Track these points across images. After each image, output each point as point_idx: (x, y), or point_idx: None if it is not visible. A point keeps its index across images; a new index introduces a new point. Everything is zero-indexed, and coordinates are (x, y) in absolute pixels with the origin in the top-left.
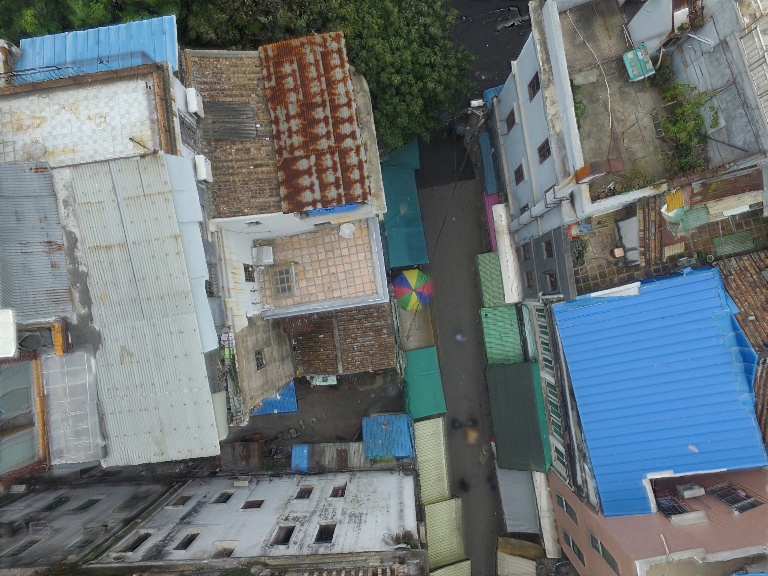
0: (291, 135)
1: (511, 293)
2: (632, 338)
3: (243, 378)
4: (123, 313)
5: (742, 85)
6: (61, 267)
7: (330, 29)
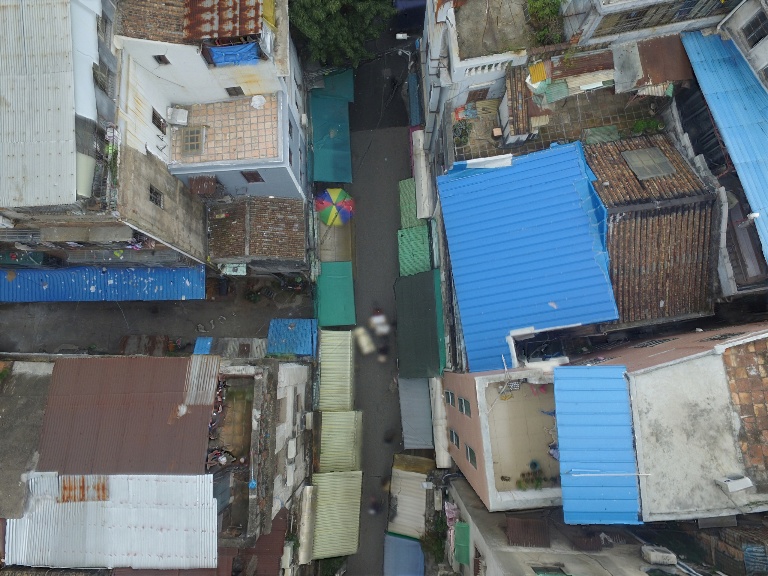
0: None
1: (423, 209)
2: (503, 205)
3: (127, 186)
4: (8, 66)
5: None
6: None
7: None
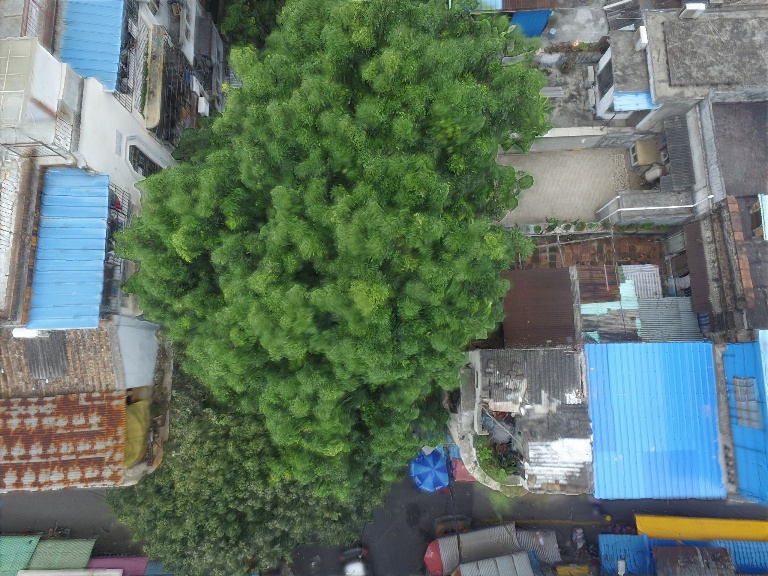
0: (21, 417)
1: None
2: None
3: None
4: None
5: None
6: None
7: None
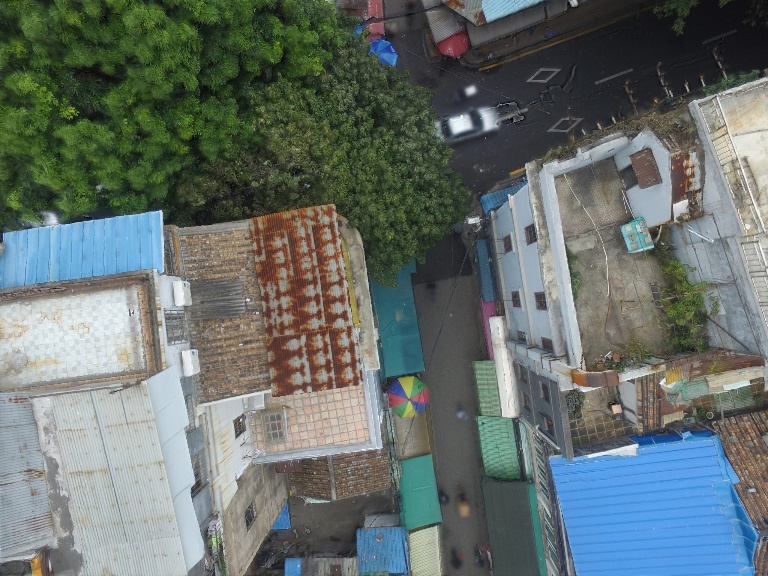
0: (281, 313)
1: (508, 408)
2: (630, 499)
3: (231, 556)
4: (105, 536)
5: (743, 288)
6: (42, 493)
7: (323, 185)
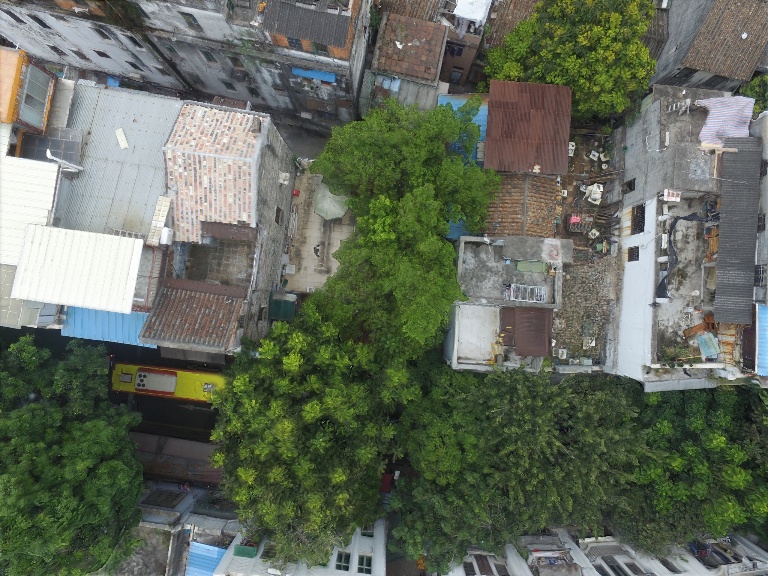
0: None
1: None
2: None
3: None
4: None
5: None
6: None
7: None
